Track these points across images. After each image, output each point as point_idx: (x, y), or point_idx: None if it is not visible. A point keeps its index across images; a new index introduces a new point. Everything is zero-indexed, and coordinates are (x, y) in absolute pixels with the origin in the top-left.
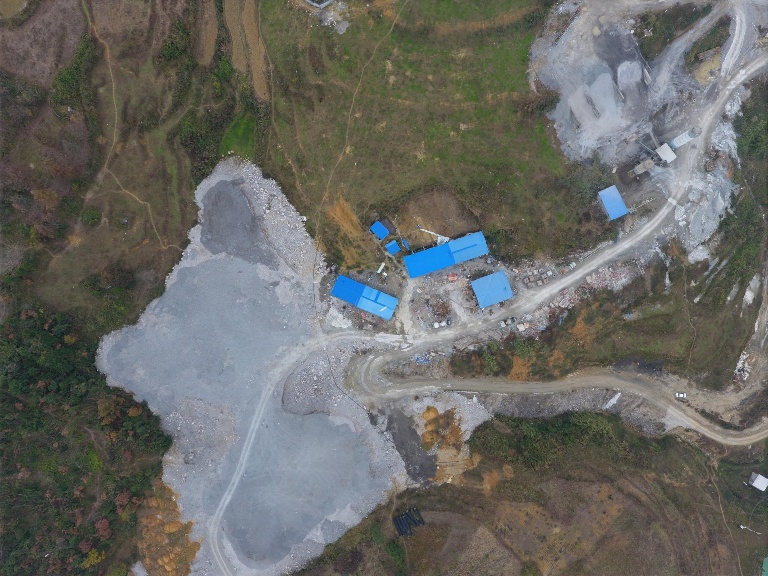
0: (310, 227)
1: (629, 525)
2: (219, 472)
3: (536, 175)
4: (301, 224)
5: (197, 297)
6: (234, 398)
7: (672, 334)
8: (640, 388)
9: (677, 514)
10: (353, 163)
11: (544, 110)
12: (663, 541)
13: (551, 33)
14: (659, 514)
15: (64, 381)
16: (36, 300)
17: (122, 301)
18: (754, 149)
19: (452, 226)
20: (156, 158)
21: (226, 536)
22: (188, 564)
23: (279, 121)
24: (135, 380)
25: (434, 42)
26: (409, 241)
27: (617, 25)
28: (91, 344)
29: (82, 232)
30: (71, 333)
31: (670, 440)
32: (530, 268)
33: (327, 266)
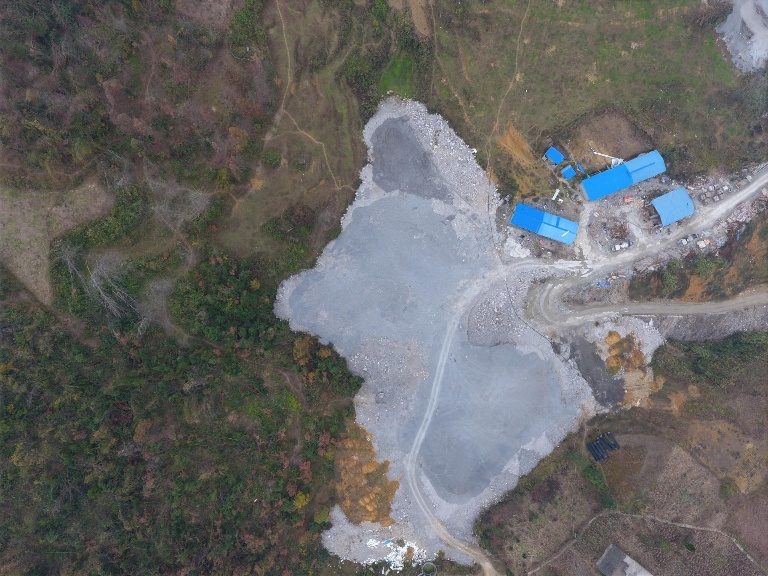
0: (481, 159)
1: None
2: (411, 409)
3: (709, 89)
4: (472, 156)
5: (374, 236)
6: (420, 334)
7: None
8: None
9: None
10: (524, 90)
11: (716, 22)
12: None
13: None
14: None
15: (253, 327)
16: (220, 247)
17: (302, 244)
18: None
19: (625, 147)
20: (326, 98)
21: (424, 472)
22: (389, 503)
23: (442, 55)
24: (319, 323)
25: None
26: (583, 165)
27: None
28: (270, 291)
29: (263, 174)
30: (255, 278)
31: None
32: (704, 185)
33: (501, 197)
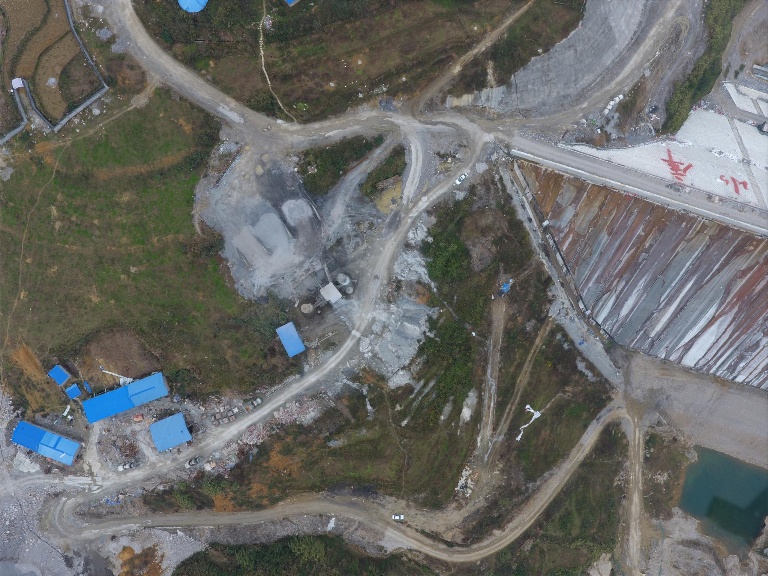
0: None
1: None
2: None
3: (212, 314)
4: None
5: None
6: None
7: (382, 458)
8: (355, 512)
9: None
10: (28, 308)
11: (210, 252)
12: None
13: (213, 174)
14: None
15: None
16: None
17: None
18: (448, 272)
19: (135, 366)
20: None
21: None
22: None
23: None
24: None
25: (96, 187)
26: (91, 384)
27: (280, 163)
28: None
29: None
30: None
31: (392, 561)
32: (217, 405)
33: (14, 410)
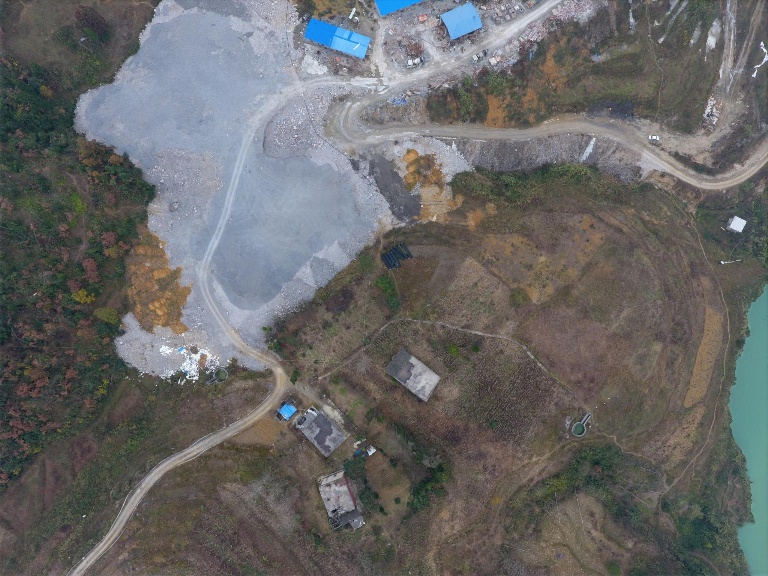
0: None
1: (612, 252)
2: (205, 218)
3: None
4: None
5: (172, 51)
6: (215, 146)
7: (640, 75)
8: (614, 133)
9: (658, 245)
10: None
11: None
12: (646, 267)
13: None
14: (641, 243)
15: (43, 132)
16: (9, 52)
17: (97, 55)
18: None
19: None
20: None
21: (216, 279)
22: (180, 308)
23: None
24: (115, 134)
25: None
26: None
27: None
28: (68, 105)
29: None
30: (47, 86)
31: (647, 185)
32: (497, 5)
33: (299, 16)
